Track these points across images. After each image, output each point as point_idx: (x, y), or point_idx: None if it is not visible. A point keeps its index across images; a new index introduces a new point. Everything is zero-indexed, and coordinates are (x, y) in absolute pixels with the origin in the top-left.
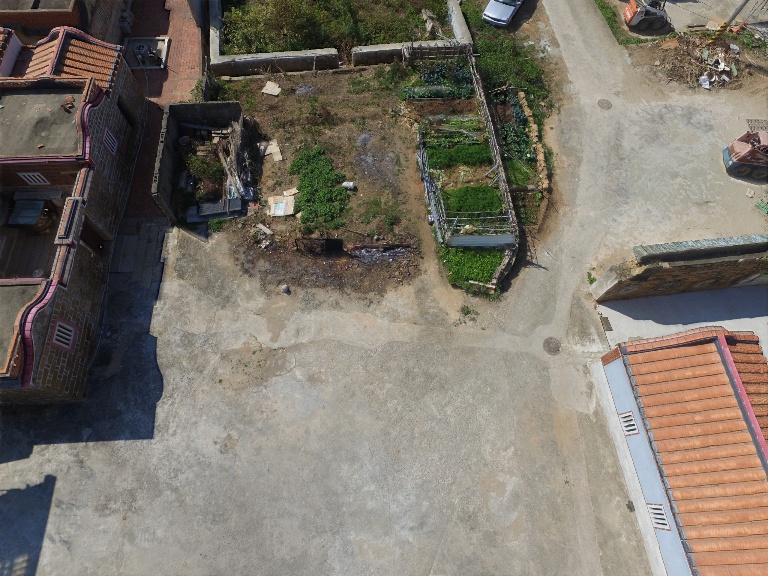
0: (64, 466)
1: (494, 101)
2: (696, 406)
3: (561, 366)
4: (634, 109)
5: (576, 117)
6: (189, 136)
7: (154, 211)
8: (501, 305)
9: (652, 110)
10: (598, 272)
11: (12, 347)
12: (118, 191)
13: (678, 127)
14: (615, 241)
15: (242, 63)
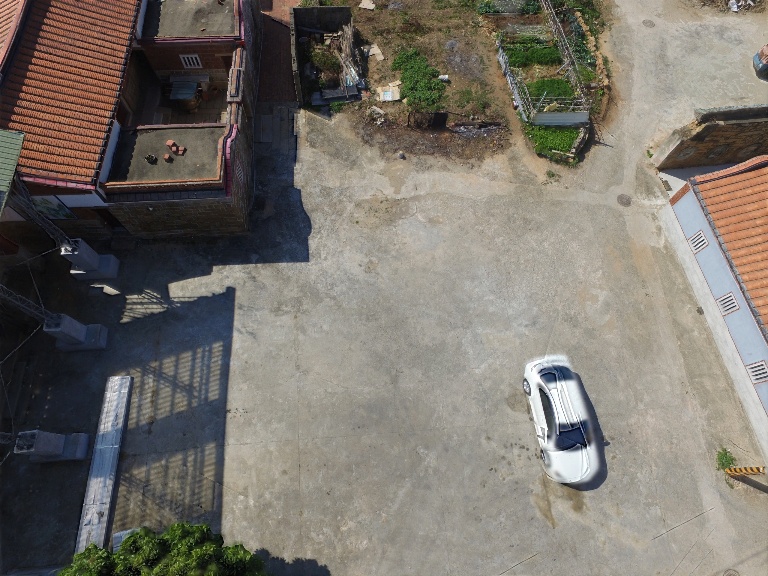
0: (240, 281)
1: (555, 19)
2: (757, 213)
3: (634, 214)
4: (674, 27)
5: (625, 33)
6: None
7: (282, 97)
8: (579, 171)
9: (689, 28)
10: (655, 150)
11: (220, 163)
12: (253, 79)
13: (713, 41)
14: (667, 127)
15: None
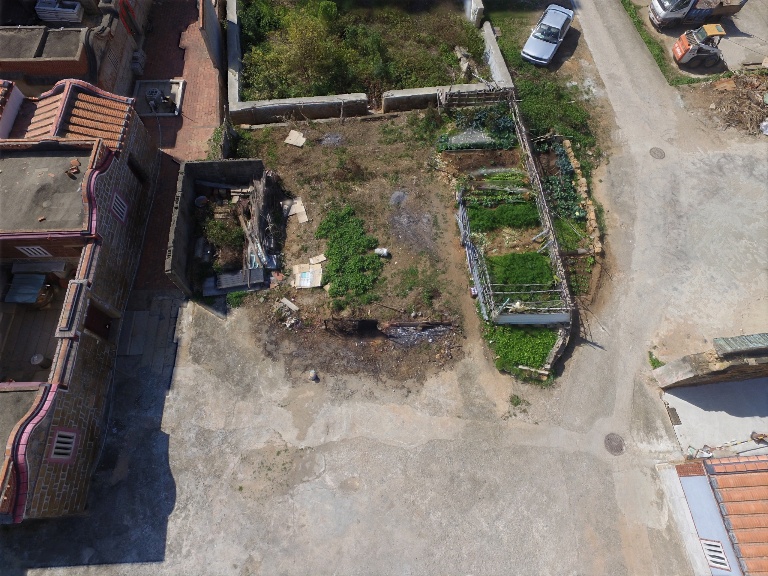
0: None
1: (537, 150)
2: None
3: (626, 469)
4: (690, 159)
5: (627, 168)
6: (206, 195)
7: (167, 282)
8: (554, 393)
9: (710, 160)
10: (660, 351)
11: (2, 477)
12: (127, 260)
13: (739, 180)
14: (677, 314)
15: (263, 110)
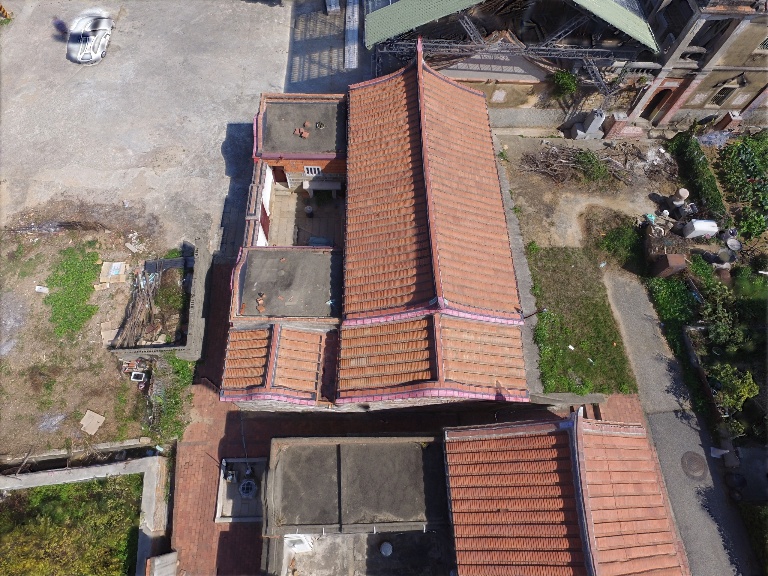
0: None
1: None
2: None
3: None
4: None
5: None
6: None
7: (229, 270)
8: None
9: None
10: None
11: (261, 105)
12: None
13: None
14: None
15: None
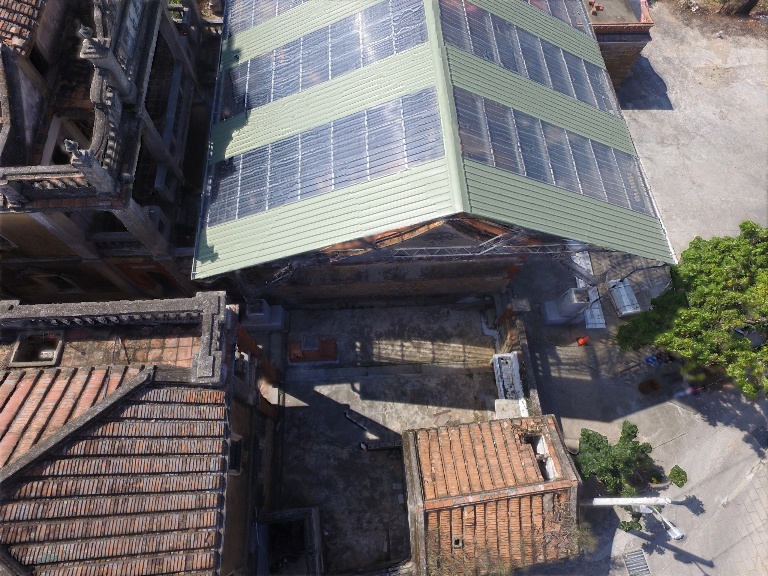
0: None
1: None
2: None
3: None
4: None
5: None
6: None
7: None
8: None
9: None
10: None
11: None
12: None
13: None
14: None
15: None
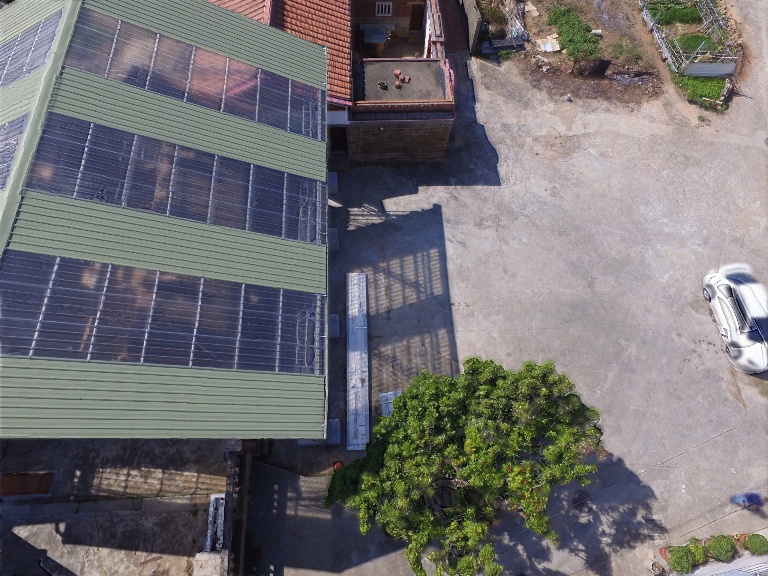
0: (444, 199)
1: None
2: None
3: None
4: None
5: None
6: None
7: (454, 46)
8: (726, 117)
9: None
10: None
11: (450, 87)
12: None
13: None
14: None
15: None
